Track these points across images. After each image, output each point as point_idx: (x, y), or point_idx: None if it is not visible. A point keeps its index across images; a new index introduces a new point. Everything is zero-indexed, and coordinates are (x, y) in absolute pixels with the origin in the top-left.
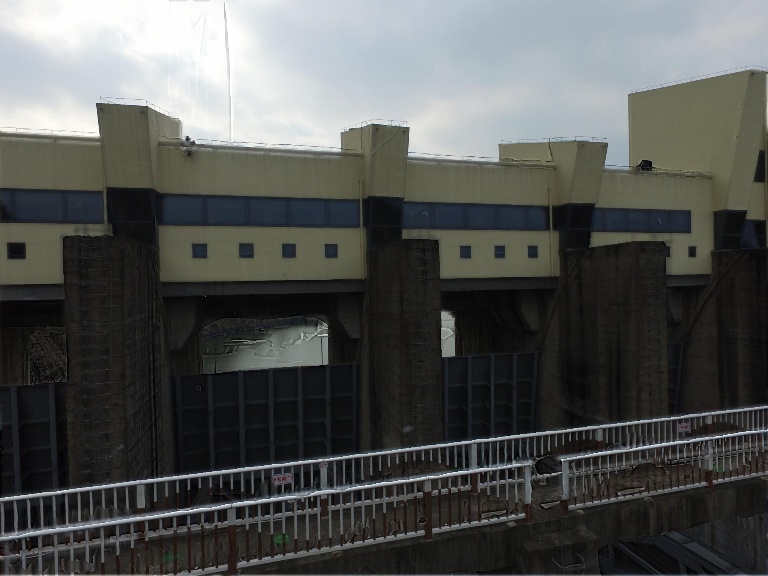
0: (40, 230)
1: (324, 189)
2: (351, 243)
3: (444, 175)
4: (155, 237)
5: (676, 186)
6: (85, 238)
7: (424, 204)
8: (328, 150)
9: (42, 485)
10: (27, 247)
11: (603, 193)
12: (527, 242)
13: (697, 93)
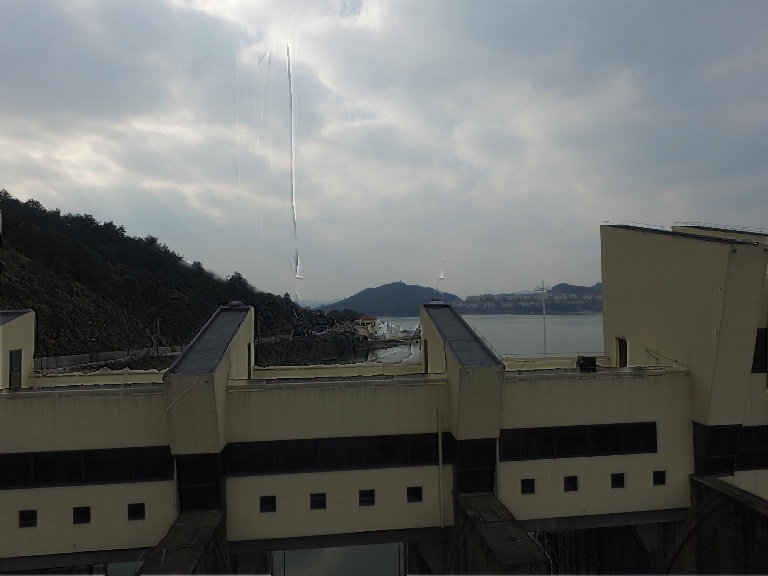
0: None
1: (129, 435)
2: (163, 500)
3: (290, 405)
4: None
5: (633, 390)
6: None
7: (262, 444)
8: (136, 387)
9: None
10: None
11: (520, 408)
12: (406, 482)
13: (671, 254)
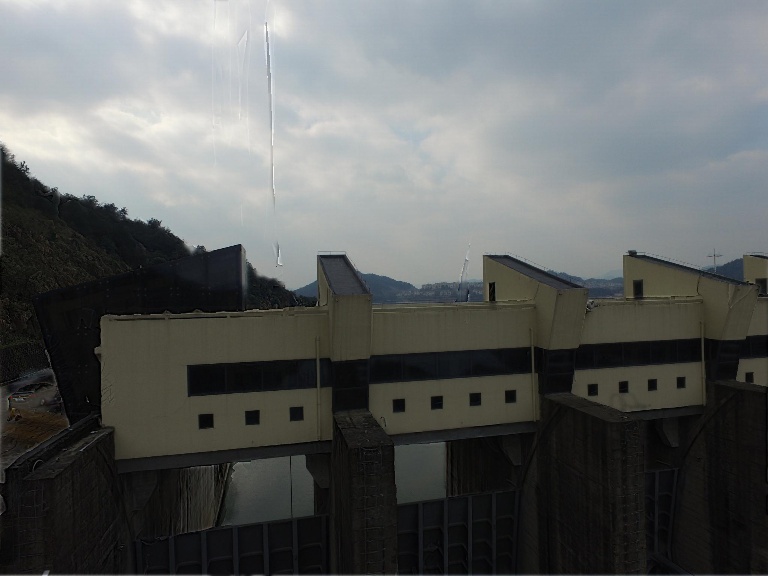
0: (489, 382)
1: (675, 331)
2: (694, 375)
3: (759, 312)
4: None
5: None
6: (626, 424)
7: None
8: (678, 299)
9: (448, 575)
10: (482, 396)
11: None
12: None
13: None
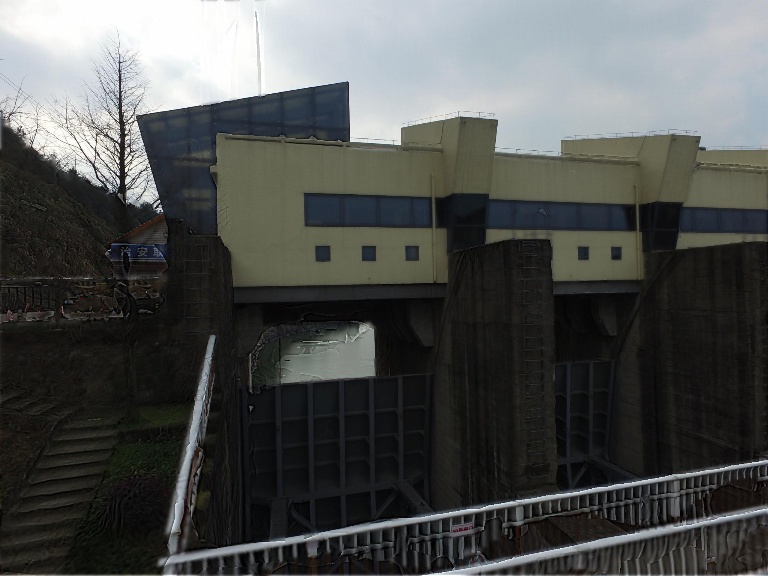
0: (596, 236)
1: (767, 202)
2: None
3: None
4: (676, 242)
5: None
6: None
7: None
8: None
9: None
10: (589, 250)
11: None
12: None
13: None
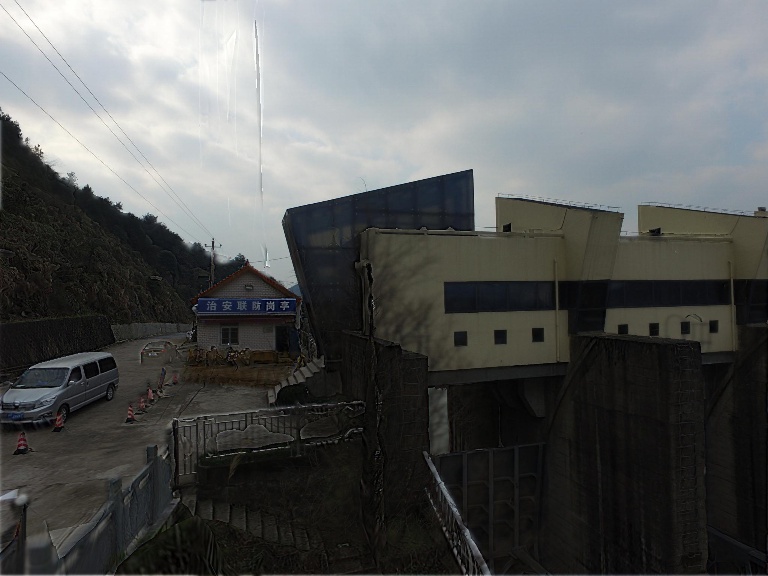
0: (696, 311)
1: None
2: None
3: None
4: (767, 315)
5: None
6: None
7: None
8: None
9: None
10: (691, 325)
11: None
12: None
13: None
